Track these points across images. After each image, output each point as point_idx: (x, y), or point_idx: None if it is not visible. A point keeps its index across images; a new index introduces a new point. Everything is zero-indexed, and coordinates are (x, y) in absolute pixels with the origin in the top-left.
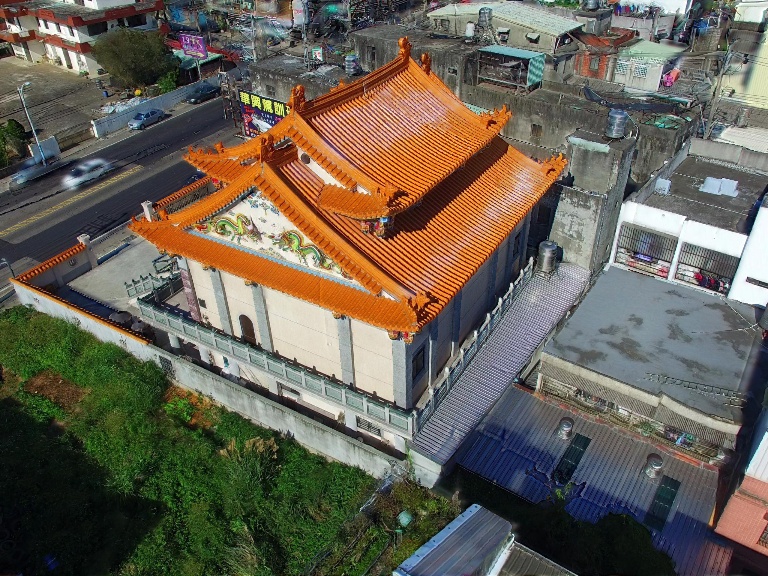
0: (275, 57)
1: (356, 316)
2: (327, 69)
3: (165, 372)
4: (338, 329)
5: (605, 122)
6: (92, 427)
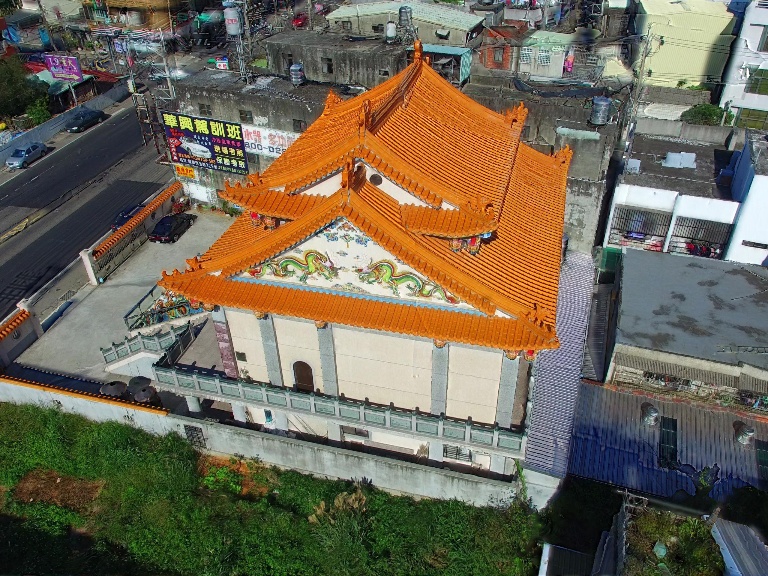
0: (199, 72)
1: (477, 342)
2: (267, 81)
3: (191, 442)
4: (433, 359)
5: (549, 110)
6: (129, 526)
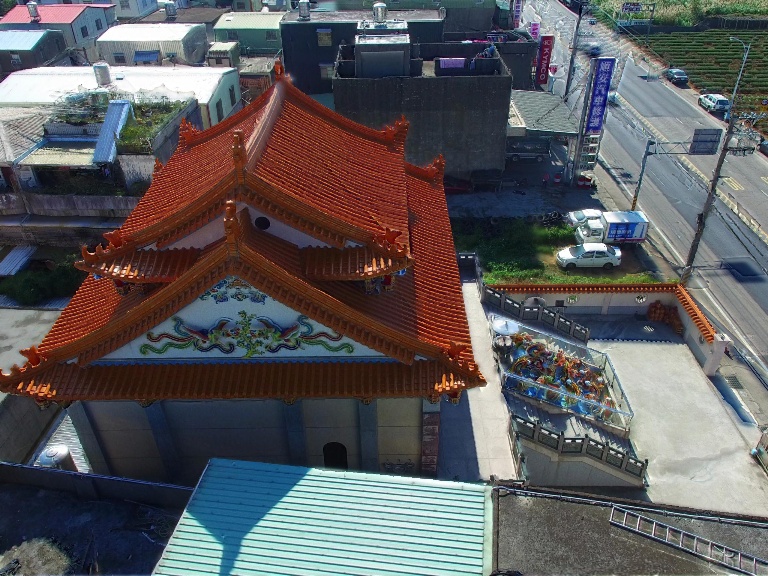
0: None
1: None
2: None
3: None
4: None
5: None
6: None
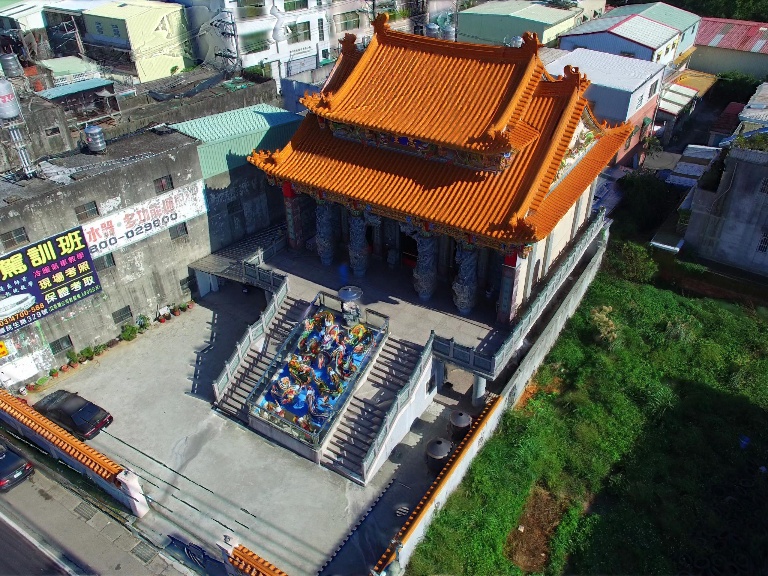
0: None
1: None
2: (51, 167)
3: None
4: None
5: (227, 100)
6: None
